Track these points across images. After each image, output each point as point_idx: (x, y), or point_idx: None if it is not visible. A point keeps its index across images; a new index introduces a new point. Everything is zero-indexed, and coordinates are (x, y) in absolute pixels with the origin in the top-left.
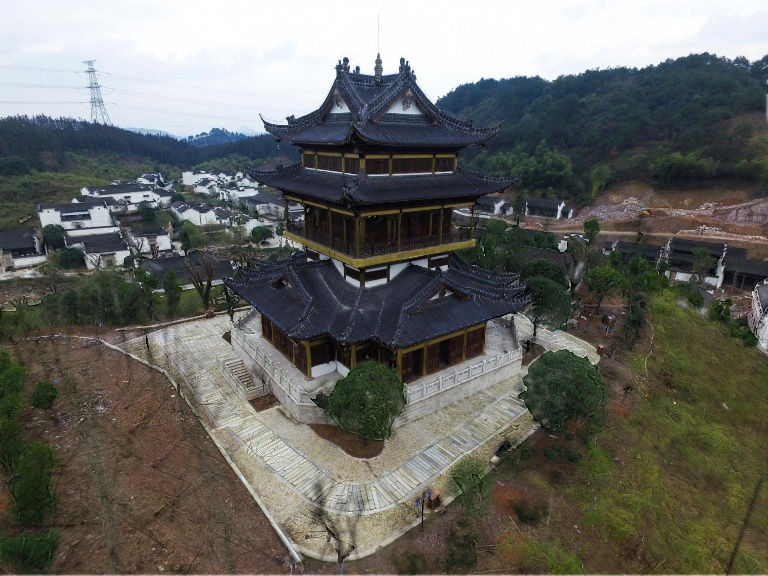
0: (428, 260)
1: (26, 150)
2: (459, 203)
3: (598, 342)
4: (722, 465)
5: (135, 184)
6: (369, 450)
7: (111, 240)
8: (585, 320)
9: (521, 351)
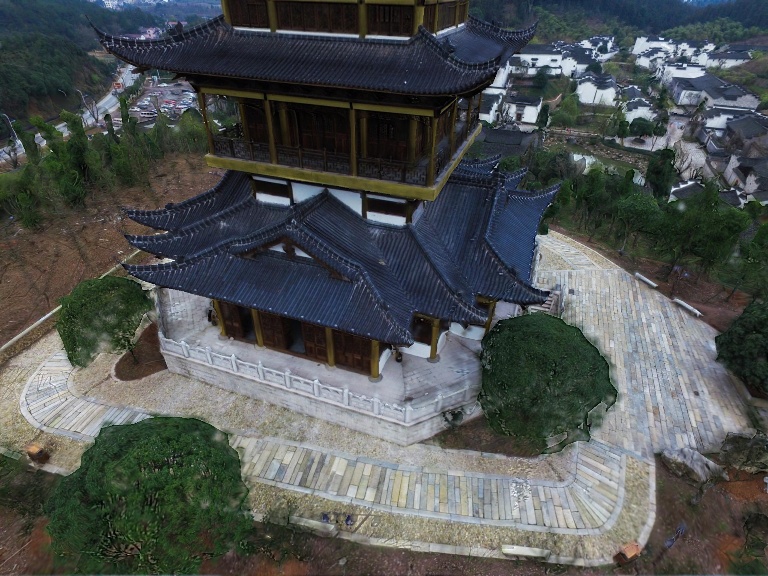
0: (362, 196)
1: (496, 3)
2: (388, 105)
3: (682, 544)
4: None
5: (552, 46)
6: (126, 370)
7: (485, 101)
8: (765, 490)
9: (413, 416)
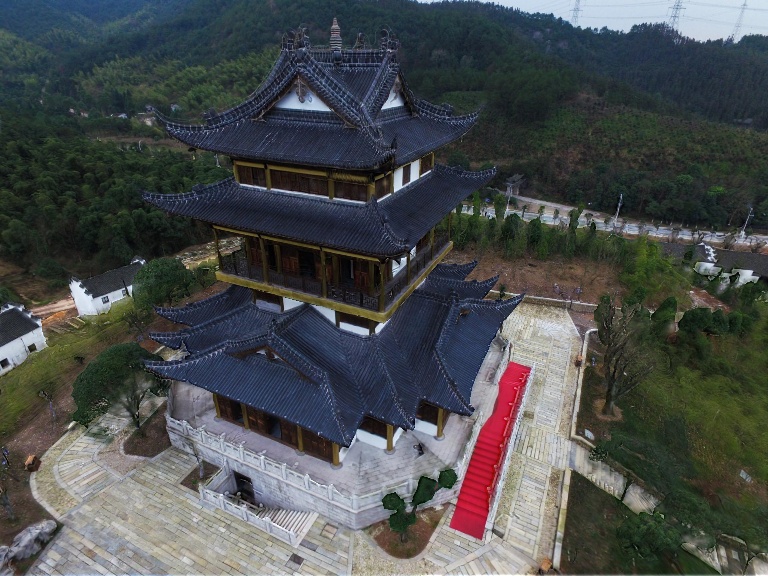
0: None
1: None
2: None
3: None
4: (45, 351)
5: None
6: None
7: None
8: None
9: None
